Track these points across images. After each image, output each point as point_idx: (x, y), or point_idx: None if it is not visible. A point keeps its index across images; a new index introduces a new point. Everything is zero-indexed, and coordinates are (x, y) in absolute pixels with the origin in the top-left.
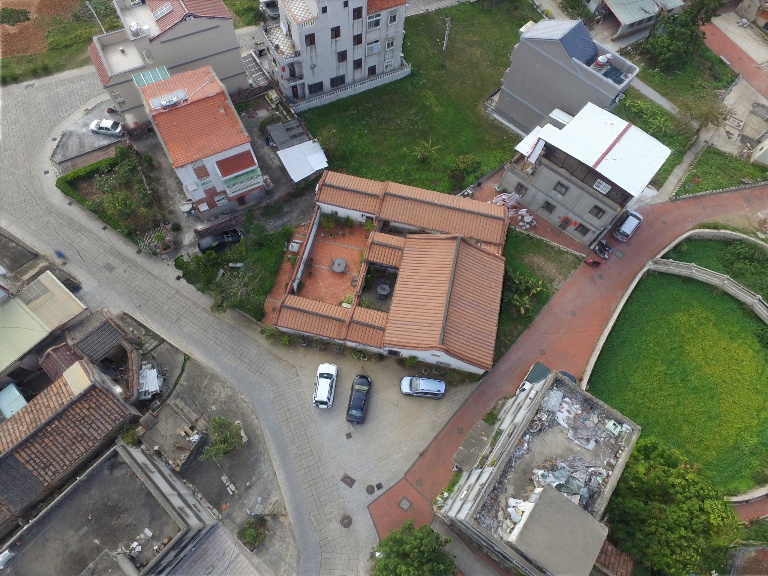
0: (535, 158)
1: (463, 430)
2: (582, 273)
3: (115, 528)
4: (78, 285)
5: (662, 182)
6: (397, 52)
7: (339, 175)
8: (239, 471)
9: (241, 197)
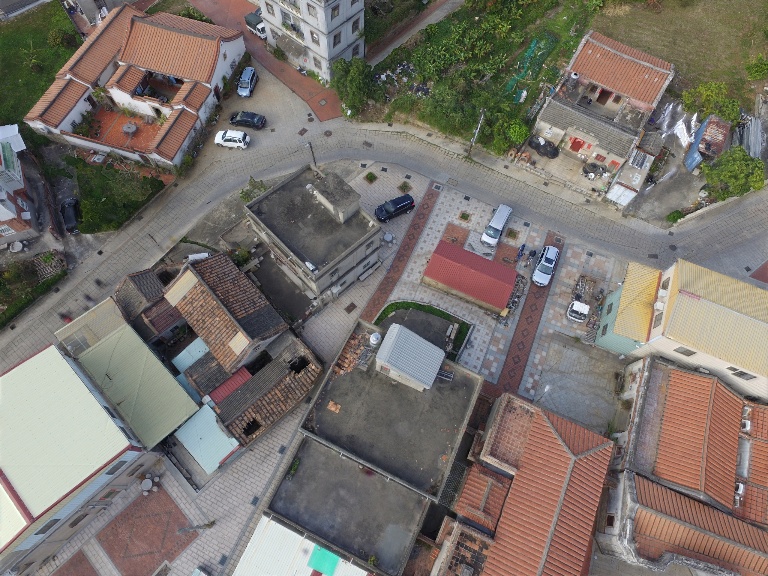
0: None
1: (282, 69)
2: None
3: (303, 206)
4: None
5: None
6: None
7: (33, 109)
8: None
9: (25, 193)
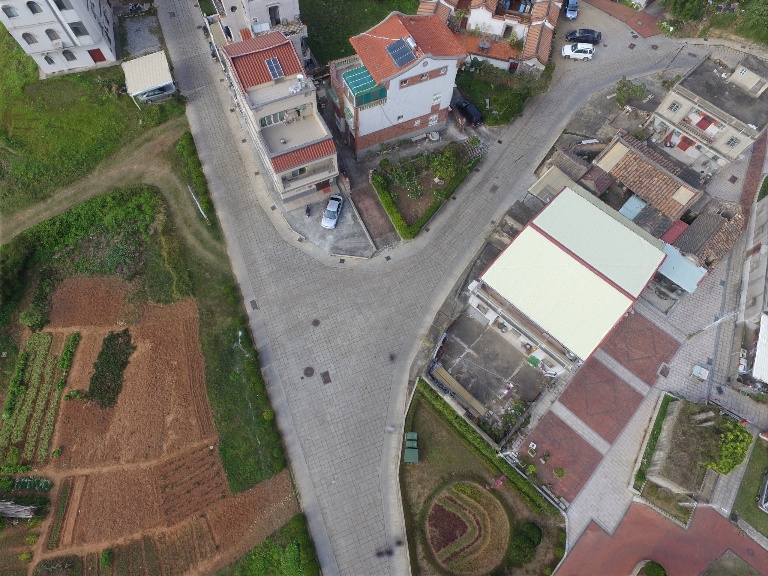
0: None
1: None
2: None
3: (718, 86)
4: None
5: None
6: None
7: None
8: None
9: None
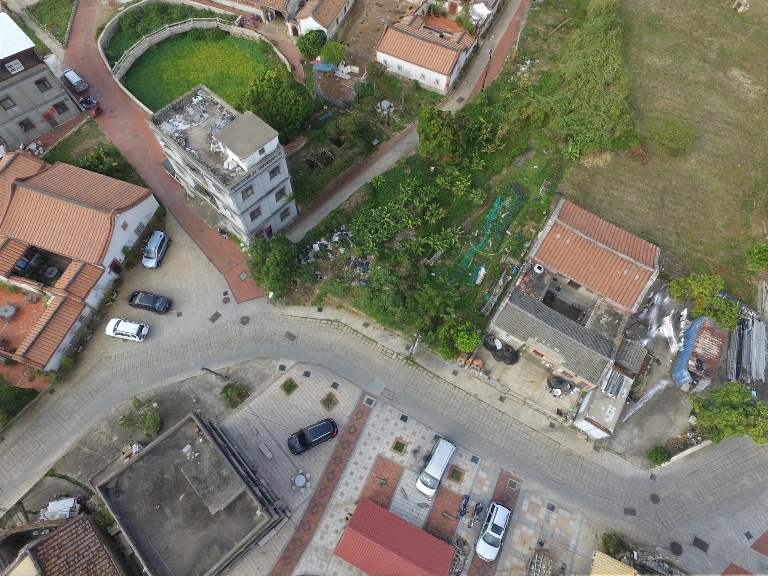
0: None
1: (201, 228)
2: (104, 122)
3: (175, 481)
4: None
5: (46, 48)
6: None
7: None
8: (182, 410)
9: None
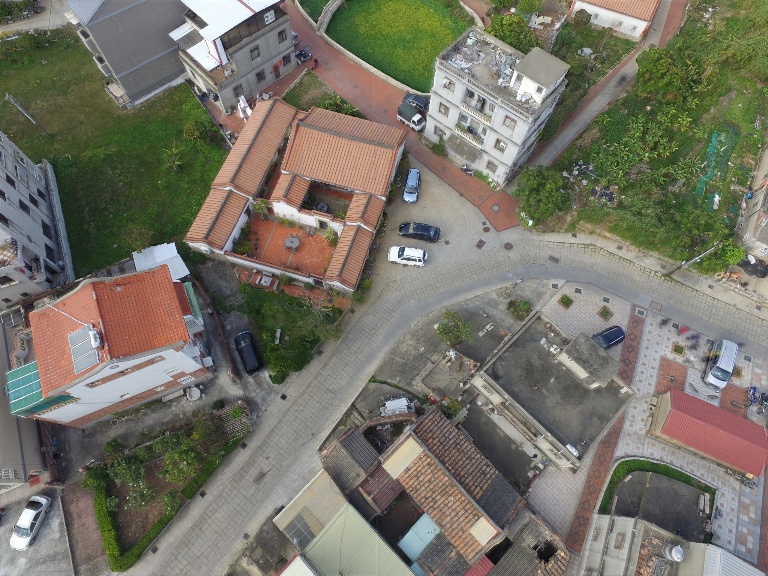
0: (225, 57)
1: (444, 167)
2: (322, 74)
3: (542, 367)
4: (278, 511)
5: None
6: (28, 162)
7: (194, 227)
8: (475, 324)
9: None
